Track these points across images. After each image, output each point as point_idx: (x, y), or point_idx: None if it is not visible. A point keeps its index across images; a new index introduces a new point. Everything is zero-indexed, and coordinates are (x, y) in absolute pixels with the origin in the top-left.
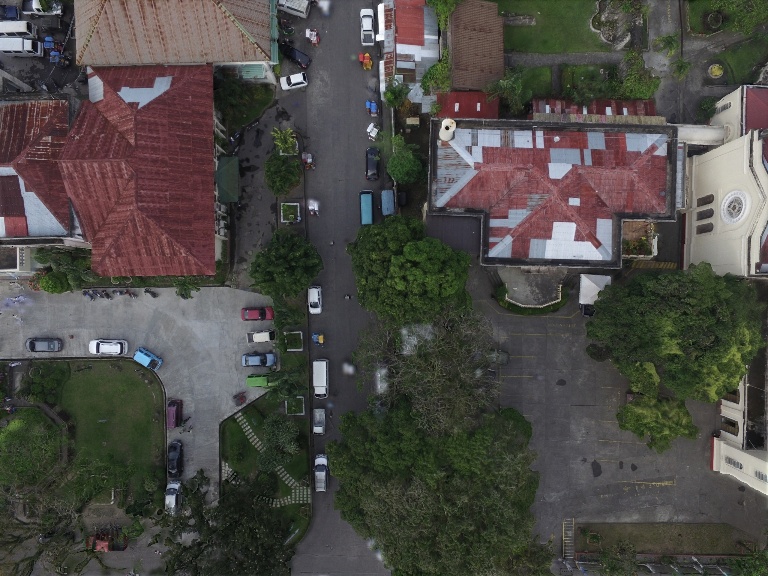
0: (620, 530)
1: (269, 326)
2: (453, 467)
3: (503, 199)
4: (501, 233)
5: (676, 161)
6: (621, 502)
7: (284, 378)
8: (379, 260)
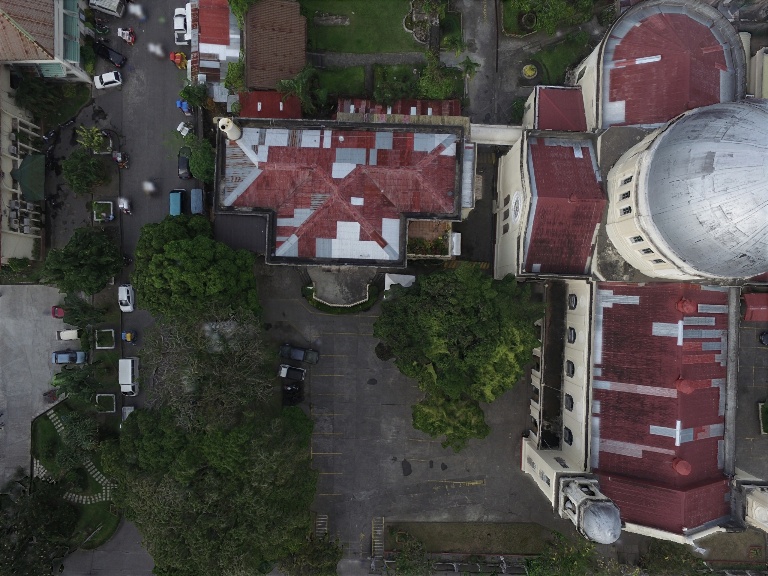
0: (429, 529)
1: None
2: (208, 465)
3: (289, 198)
4: (287, 232)
5: (462, 161)
6: (431, 501)
7: (71, 375)
8: (143, 258)
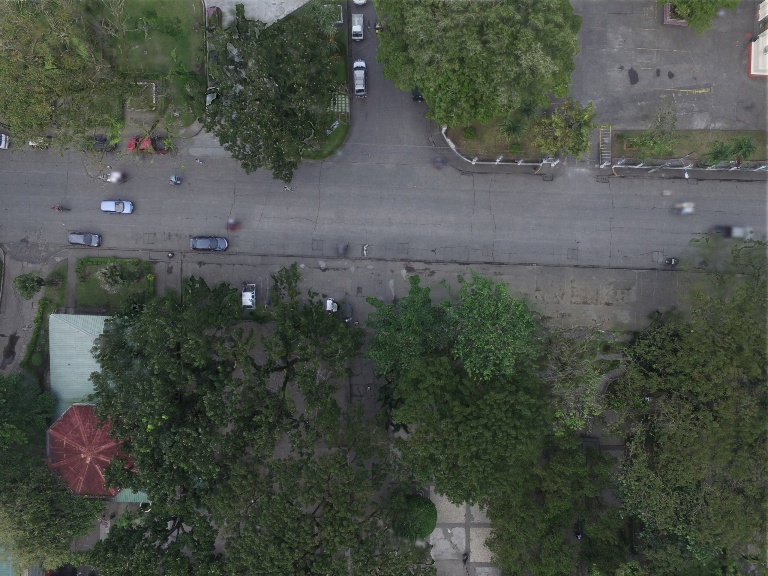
0: None
1: None
2: None
3: None
4: None
5: None
6: (658, 109)
7: None
8: None
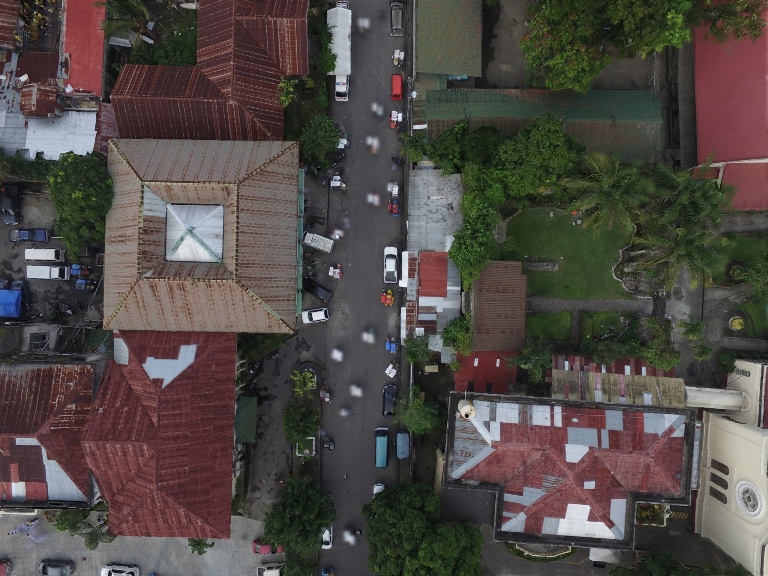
0: None
1: (279, 557)
2: None
3: (519, 475)
4: (515, 509)
5: (693, 445)
6: None
7: None
8: (393, 558)
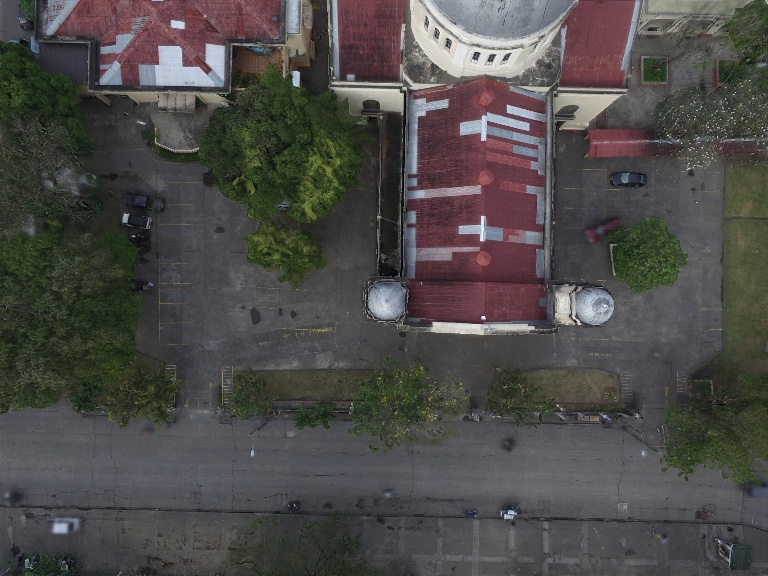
0: (280, 377)
1: None
2: None
3: (111, 25)
4: (109, 59)
5: None
6: (280, 349)
7: None
8: None
